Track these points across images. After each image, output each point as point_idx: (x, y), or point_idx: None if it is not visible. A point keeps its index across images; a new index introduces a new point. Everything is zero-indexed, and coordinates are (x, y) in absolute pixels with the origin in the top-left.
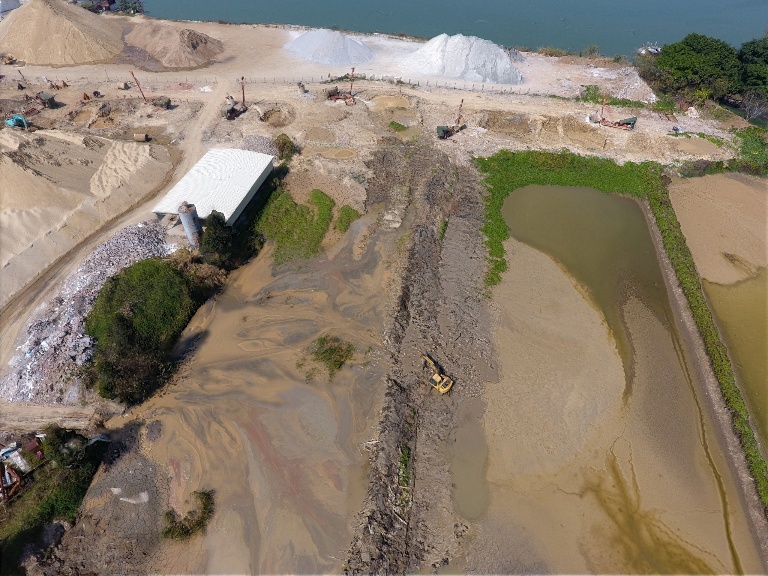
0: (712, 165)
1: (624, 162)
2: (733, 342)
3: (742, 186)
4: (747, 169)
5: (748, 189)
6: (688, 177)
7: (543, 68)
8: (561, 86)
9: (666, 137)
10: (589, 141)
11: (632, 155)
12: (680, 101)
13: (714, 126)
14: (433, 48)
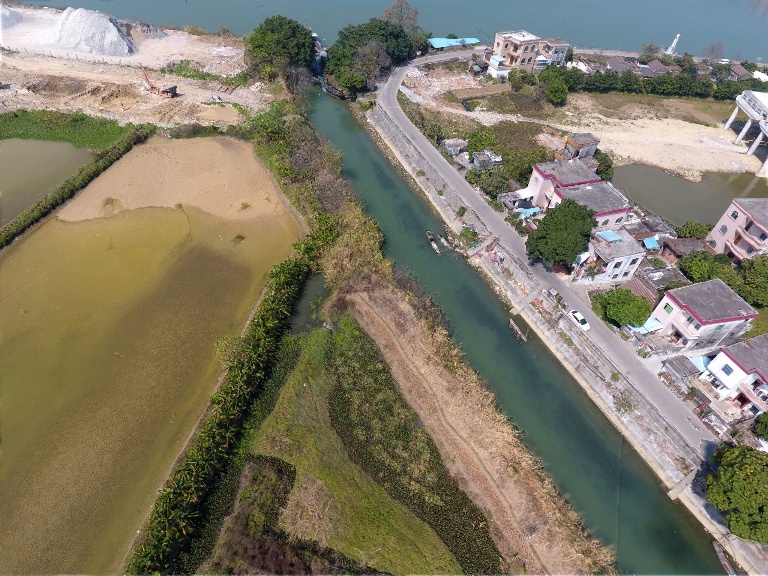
0: (208, 129)
1: (125, 123)
2: (1, 264)
3: (216, 147)
4: (236, 134)
5: (218, 150)
6: (175, 138)
7: (173, 44)
8: (166, 60)
9: (198, 105)
10: (121, 105)
11: (138, 118)
12: (256, 77)
13: (261, 98)
14: (62, 20)
